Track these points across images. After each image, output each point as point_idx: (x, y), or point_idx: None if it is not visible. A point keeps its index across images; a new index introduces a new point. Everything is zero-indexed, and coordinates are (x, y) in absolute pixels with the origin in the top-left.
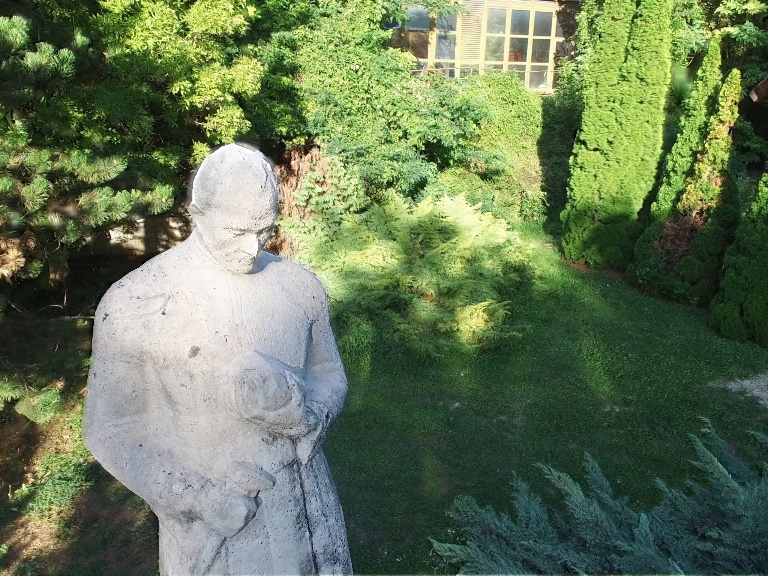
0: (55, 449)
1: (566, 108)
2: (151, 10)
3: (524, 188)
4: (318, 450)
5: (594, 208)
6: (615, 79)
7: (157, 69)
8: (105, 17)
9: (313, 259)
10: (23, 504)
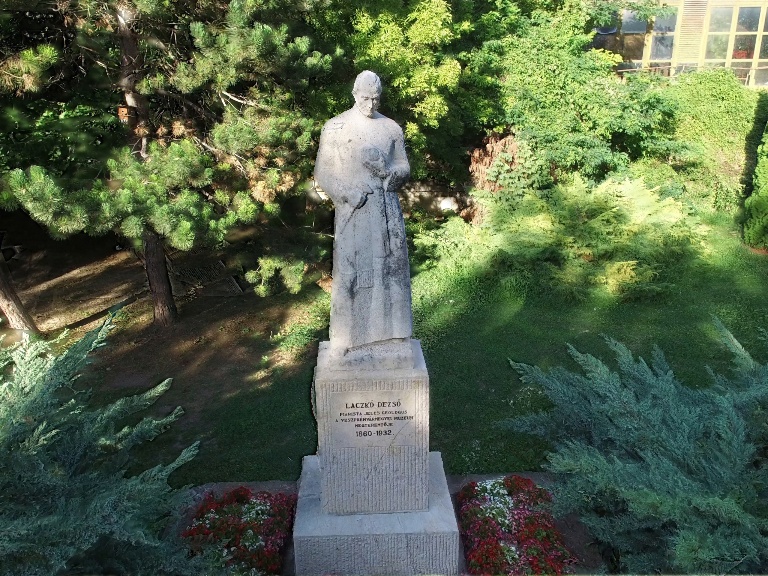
0: (298, 321)
1: None
2: (386, 29)
3: (720, 179)
4: (393, 189)
5: None
6: None
7: (385, 69)
8: (356, 36)
9: (494, 221)
10: (278, 343)
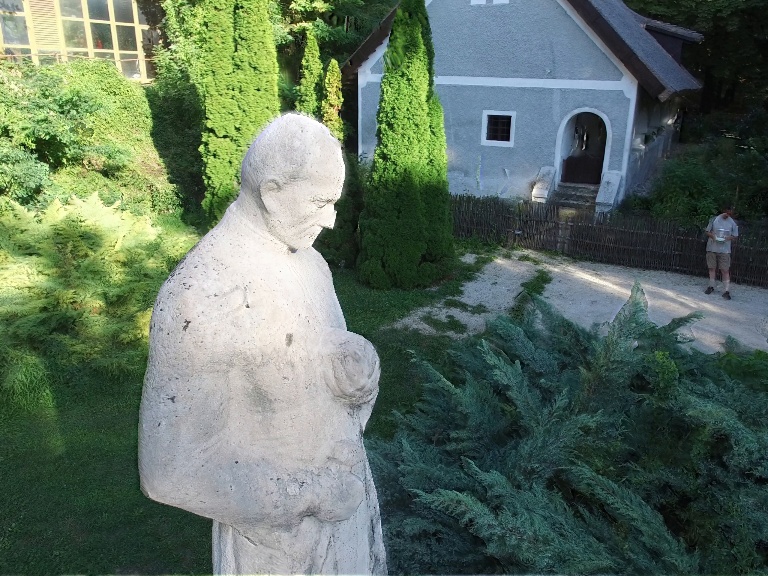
0: None
1: (173, 98)
2: None
3: (152, 182)
4: None
5: (235, 193)
6: (230, 68)
7: None
8: None
9: None
10: None
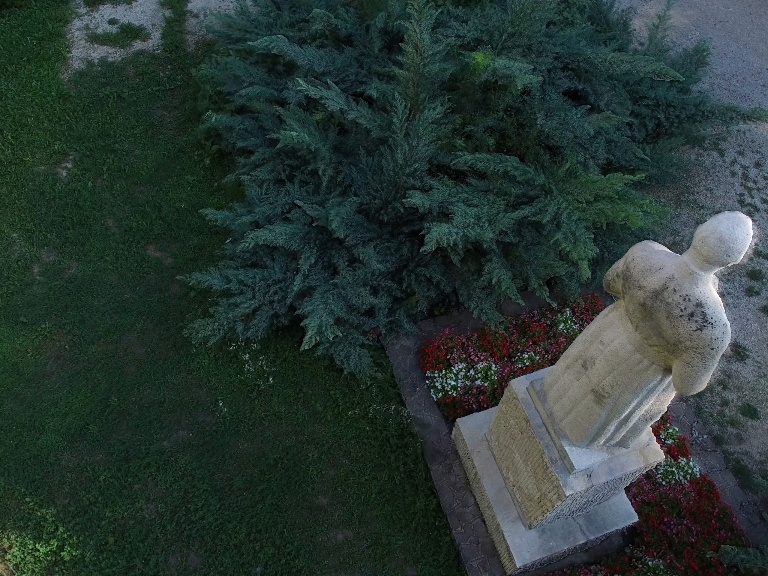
0: None
1: None
2: None
3: None
4: None
5: None
6: None
7: None
8: None
9: None
10: None
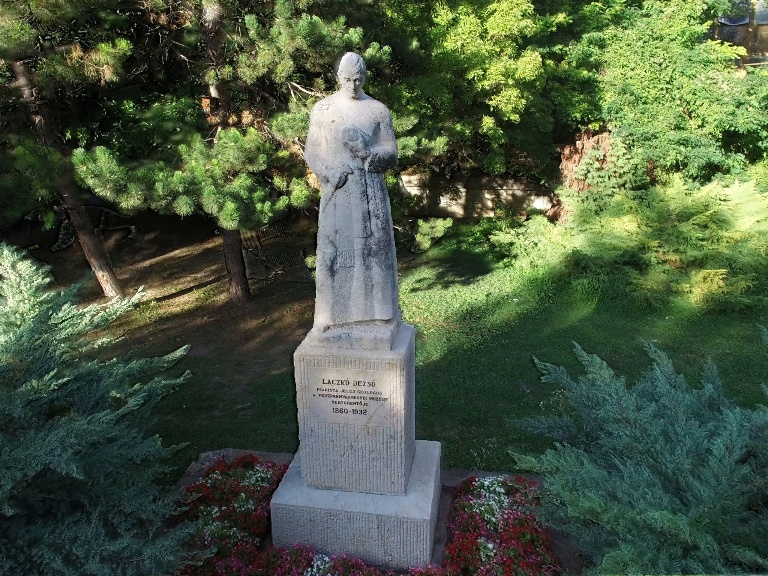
0: None
1: None
2: (466, 21)
3: None
4: None
5: None
6: None
7: (461, 62)
8: (436, 29)
9: (577, 221)
10: None
